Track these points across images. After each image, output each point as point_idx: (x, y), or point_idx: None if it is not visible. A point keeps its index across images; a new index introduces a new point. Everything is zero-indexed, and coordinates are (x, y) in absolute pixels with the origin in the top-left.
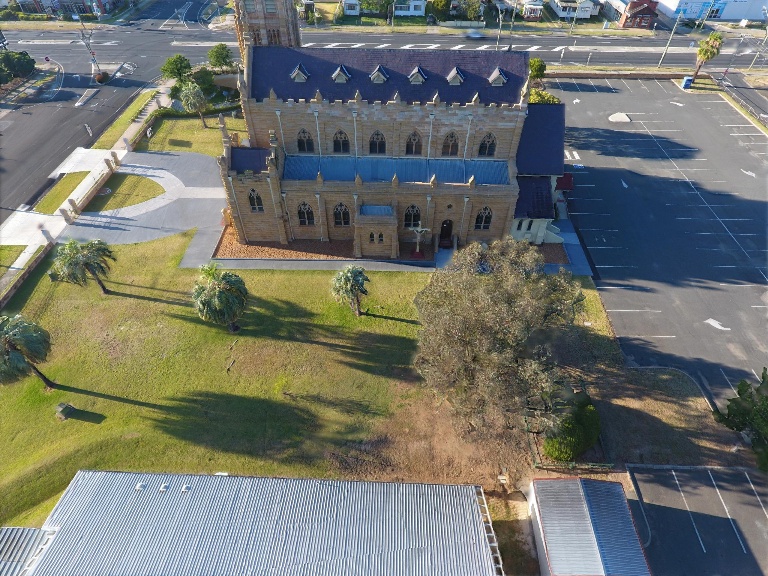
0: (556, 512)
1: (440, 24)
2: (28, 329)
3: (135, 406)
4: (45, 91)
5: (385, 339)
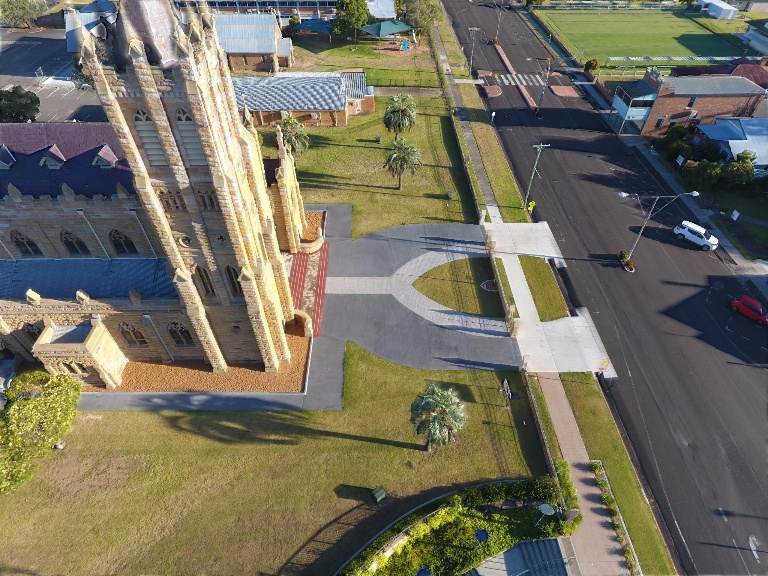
0: None
1: None
2: (389, 110)
3: None
4: None
5: None
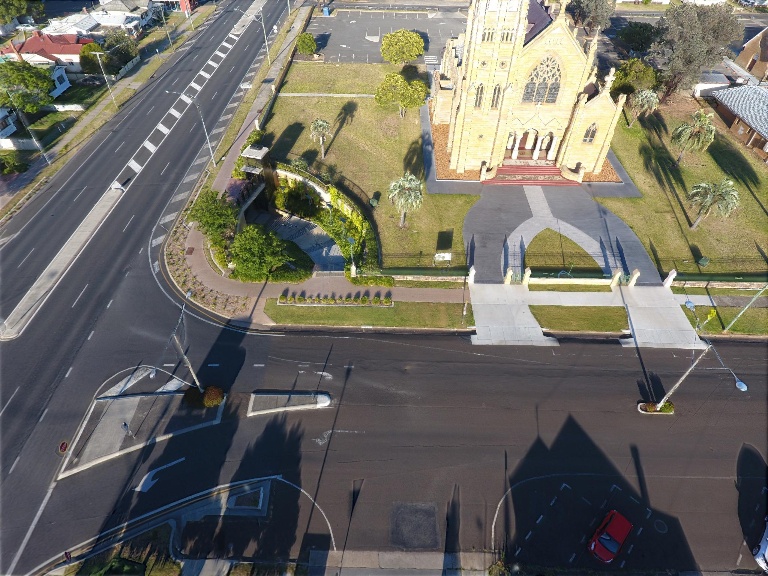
0: (708, 79)
1: (117, 78)
2: None
3: (755, 194)
4: (227, 521)
5: (642, 120)
